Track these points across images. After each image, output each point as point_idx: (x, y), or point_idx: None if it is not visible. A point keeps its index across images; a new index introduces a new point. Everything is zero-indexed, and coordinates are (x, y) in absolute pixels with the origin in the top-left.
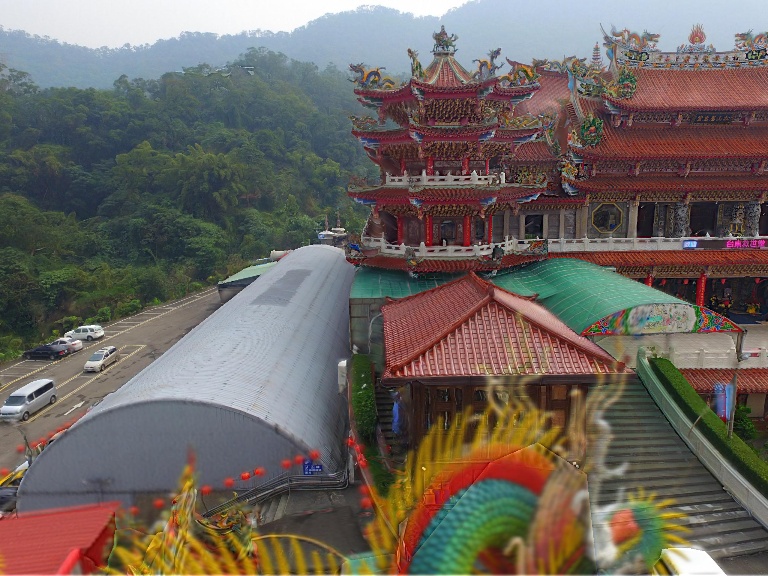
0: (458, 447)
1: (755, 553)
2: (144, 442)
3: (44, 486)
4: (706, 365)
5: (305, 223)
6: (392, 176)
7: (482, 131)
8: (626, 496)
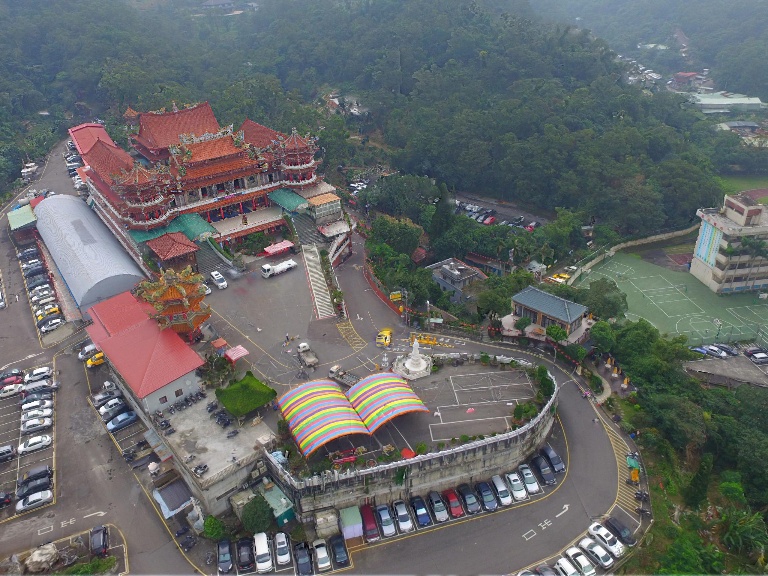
0: (176, 268)
1: None
2: (107, 287)
3: (86, 302)
4: (221, 235)
5: (5, 165)
6: (132, 203)
7: None
8: (207, 267)
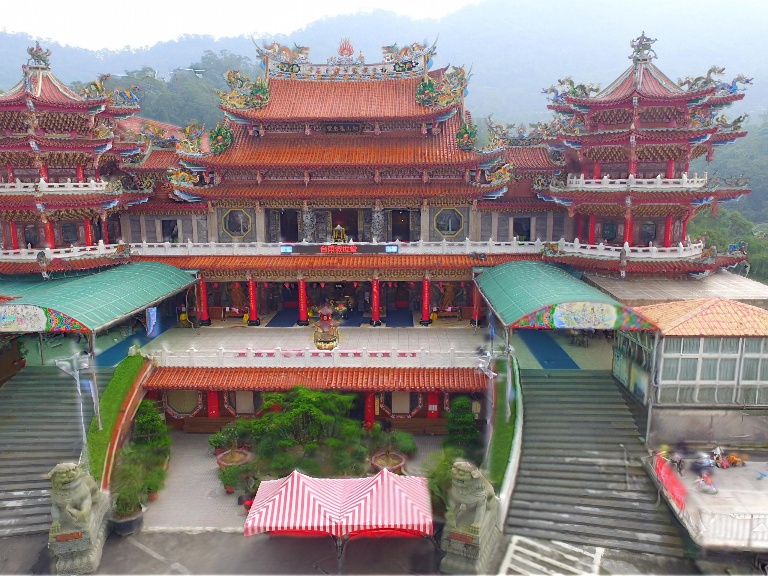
0: None
1: (35, 534)
2: None
3: None
4: (198, 364)
5: None
6: None
7: (25, 142)
8: None
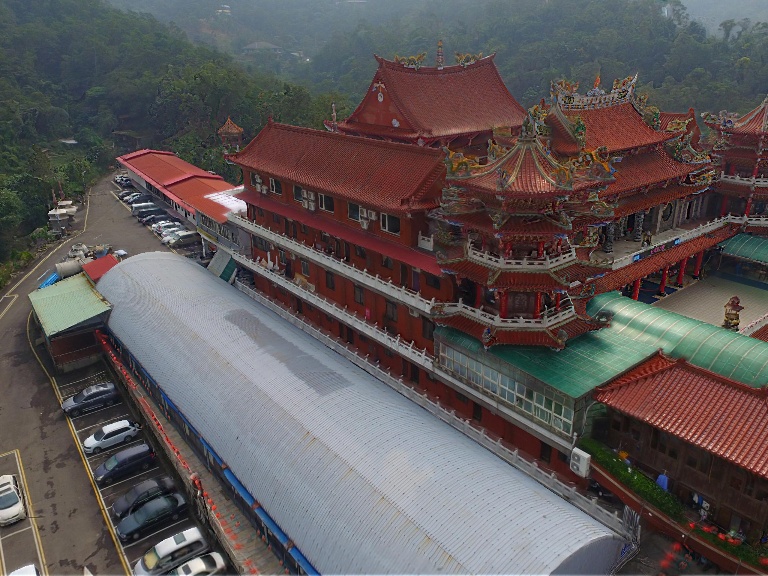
0: None
1: None
2: None
3: None
4: None
5: (15, 201)
6: (507, 259)
7: None
8: None
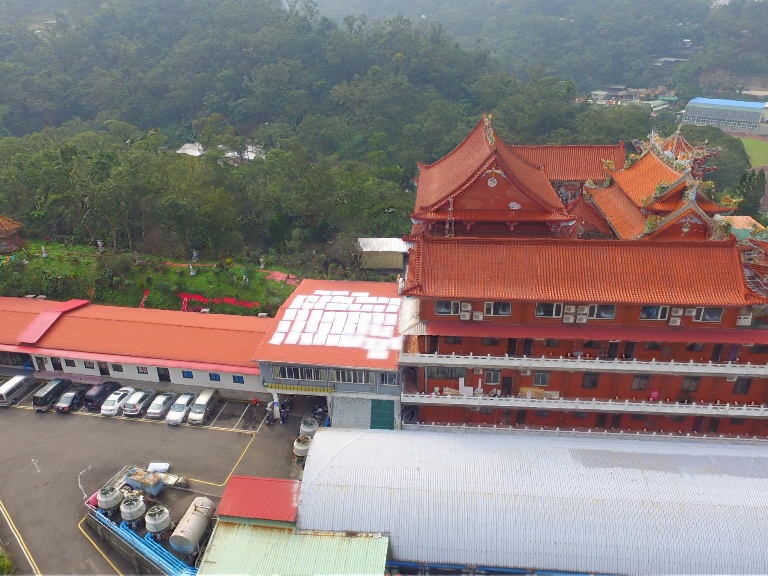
0: None
1: None
2: None
3: None
4: None
5: None
6: None
7: None
8: None
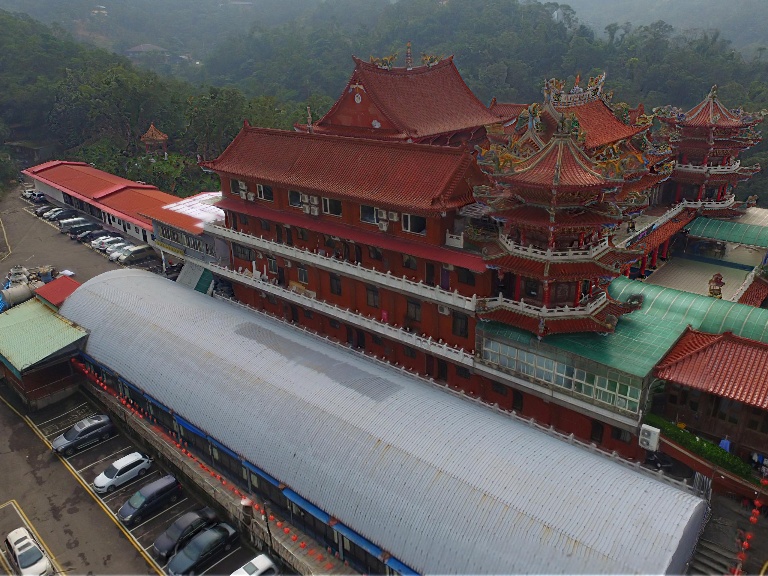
0: None
1: None
2: None
3: None
4: None
5: None
6: (554, 251)
7: None
8: None
